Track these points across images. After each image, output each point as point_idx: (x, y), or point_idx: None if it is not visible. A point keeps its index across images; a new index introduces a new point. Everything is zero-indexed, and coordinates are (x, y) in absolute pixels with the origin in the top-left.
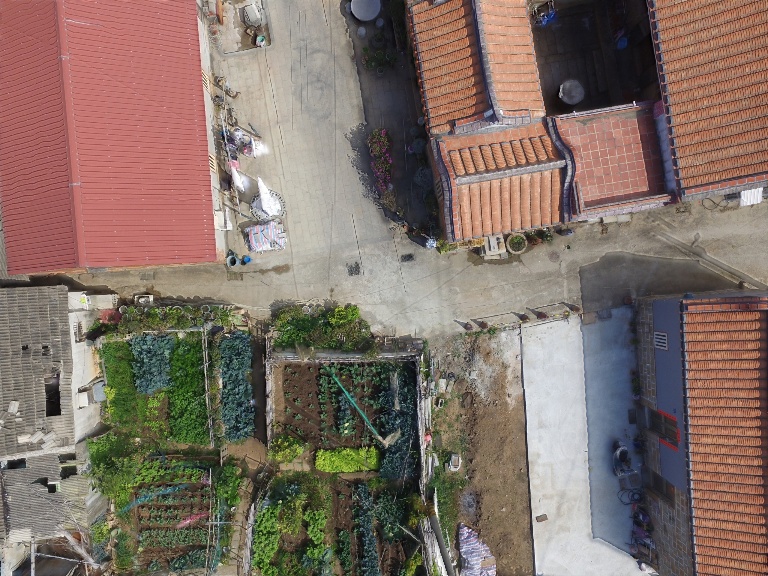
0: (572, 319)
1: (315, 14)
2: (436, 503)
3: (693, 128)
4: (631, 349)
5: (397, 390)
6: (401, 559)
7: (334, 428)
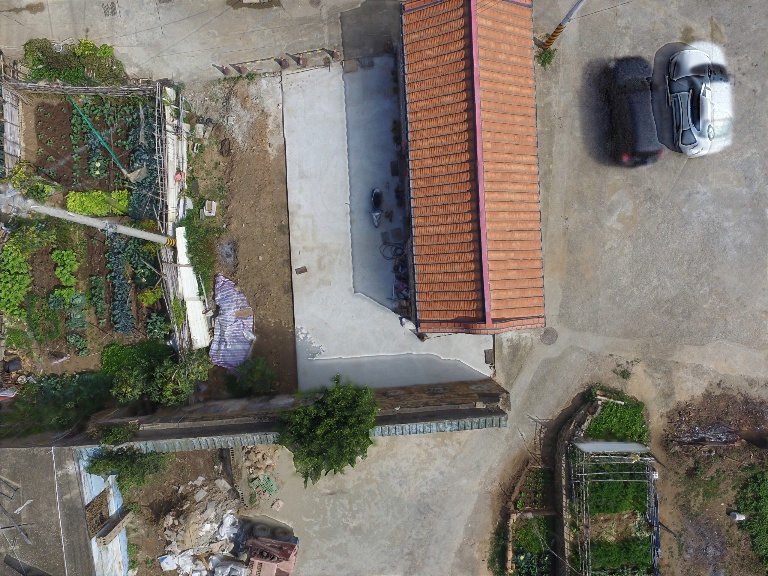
0: (334, 67)
1: None
2: (183, 241)
3: None
4: (394, 100)
5: (143, 124)
6: (156, 308)
7: (86, 170)
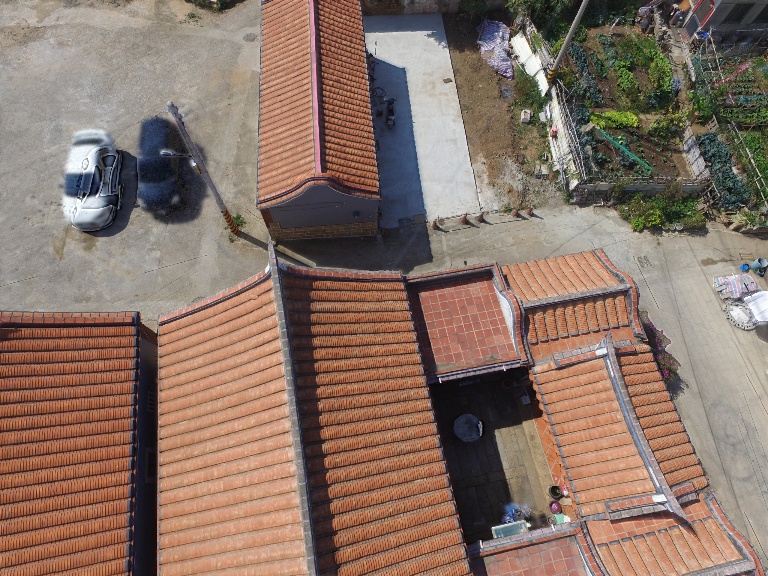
0: None
1: (763, 526)
2: (542, 86)
3: (398, 337)
4: None
5: (591, 160)
6: None
7: (629, 141)
